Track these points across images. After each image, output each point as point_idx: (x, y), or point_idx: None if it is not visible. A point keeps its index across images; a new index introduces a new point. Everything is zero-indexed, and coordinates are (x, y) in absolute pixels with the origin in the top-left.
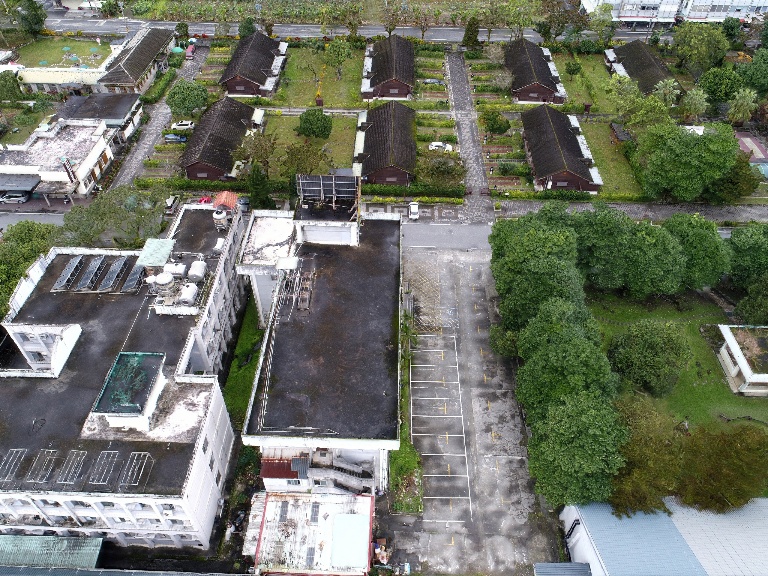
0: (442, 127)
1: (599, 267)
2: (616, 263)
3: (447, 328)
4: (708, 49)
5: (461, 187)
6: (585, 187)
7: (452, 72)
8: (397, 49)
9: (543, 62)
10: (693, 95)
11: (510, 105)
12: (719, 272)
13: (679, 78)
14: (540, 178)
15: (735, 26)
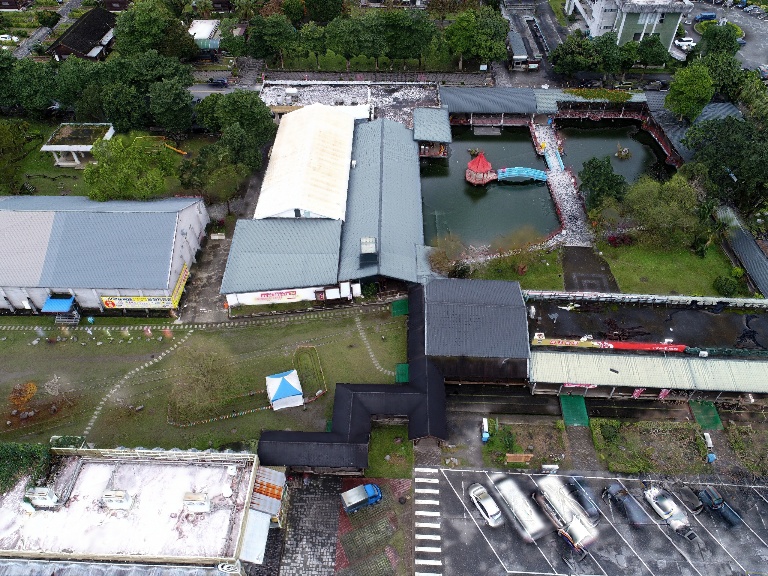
0: (27, 28)
1: None
2: (4, 87)
3: None
4: None
5: None
6: (85, 59)
7: None
8: None
9: None
10: None
11: None
12: (74, 91)
13: None
14: (46, 52)
15: None
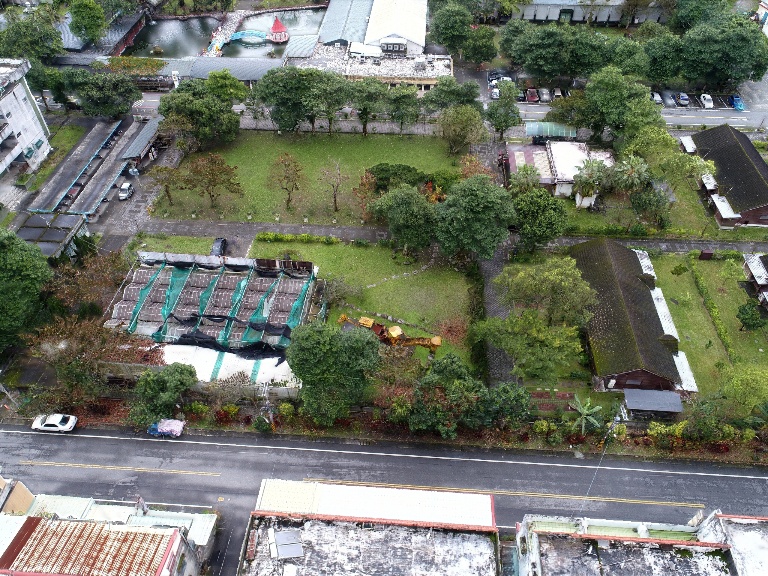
0: None
1: None
2: None
3: (766, 73)
4: None
5: None
6: None
7: None
8: None
9: None
10: (601, 162)
11: None
12: None
13: None
14: None
15: None
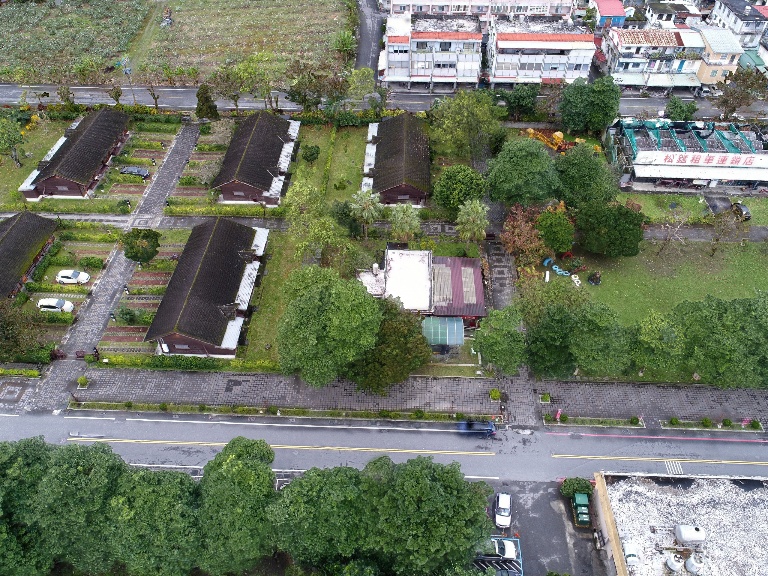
0: (101, 242)
1: (53, 552)
2: None
3: None
4: (469, 132)
5: (42, 351)
6: (215, 350)
7: (172, 154)
8: (92, 128)
9: (274, 145)
10: (396, 212)
11: (206, 208)
12: (243, 558)
13: (452, 162)
14: (146, 341)
15: (526, 96)
